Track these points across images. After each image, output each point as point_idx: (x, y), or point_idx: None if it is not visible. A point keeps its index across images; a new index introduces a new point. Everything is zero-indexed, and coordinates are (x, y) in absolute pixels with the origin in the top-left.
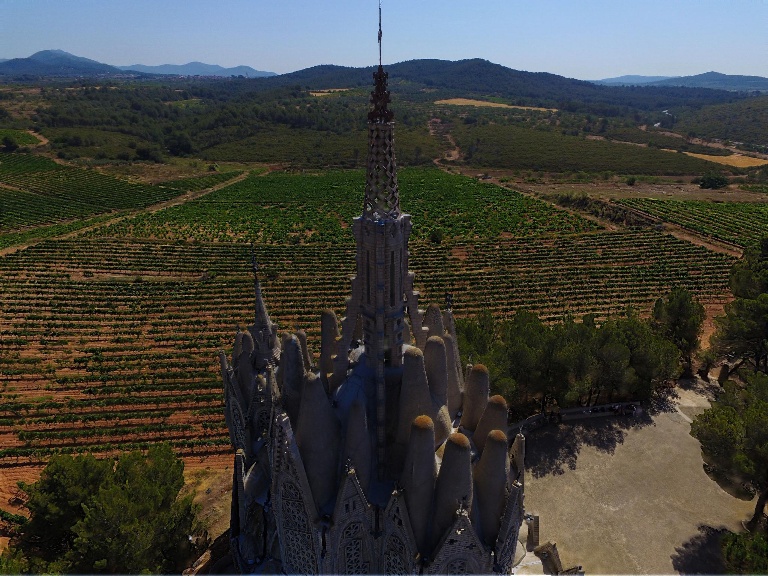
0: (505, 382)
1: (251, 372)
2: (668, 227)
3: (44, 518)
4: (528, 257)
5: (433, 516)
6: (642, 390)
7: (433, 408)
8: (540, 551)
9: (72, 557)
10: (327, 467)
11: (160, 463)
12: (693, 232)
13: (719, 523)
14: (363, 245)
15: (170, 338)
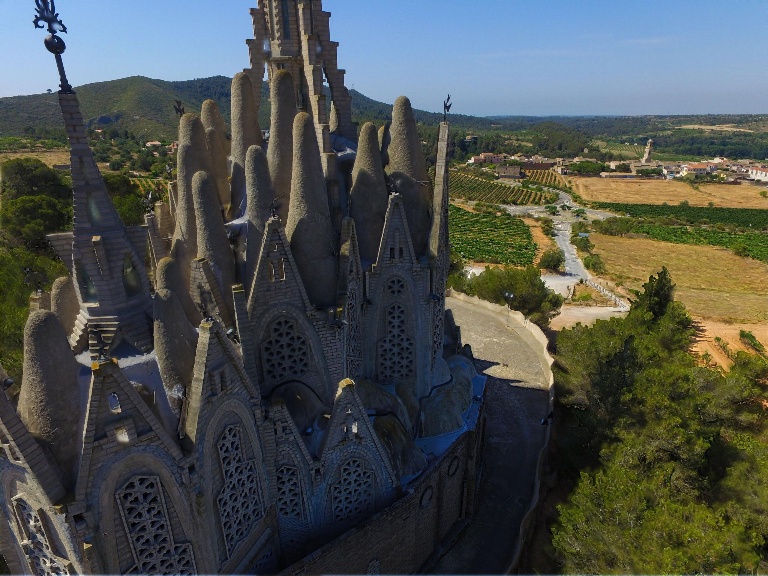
0: None
1: None
2: None
3: None
4: None
5: None
6: None
7: None
8: None
9: None
10: None
11: None
12: None
13: None
14: None
15: None
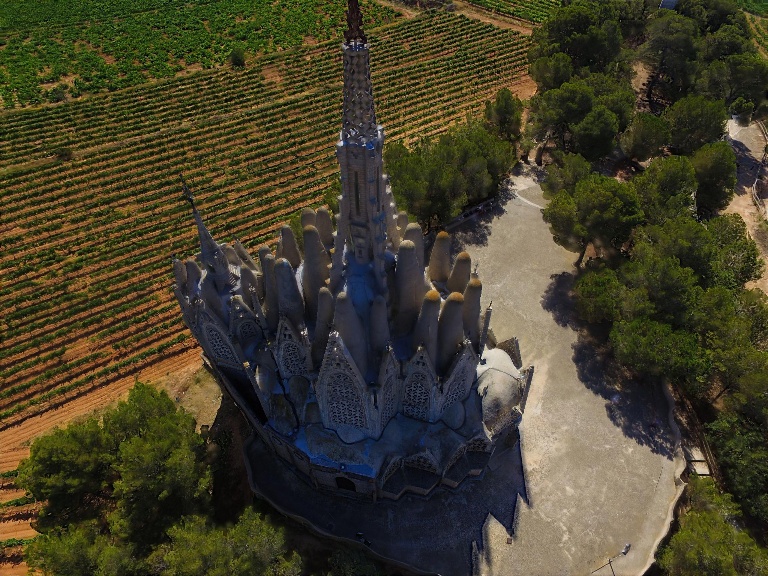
0: (410, 220)
1: (217, 295)
2: (458, 6)
3: (64, 493)
4: None
5: (439, 350)
6: (494, 188)
7: (422, 279)
8: None
9: (125, 504)
10: (363, 352)
11: None
12: (479, 8)
13: (560, 269)
14: (350, 167)
15: None
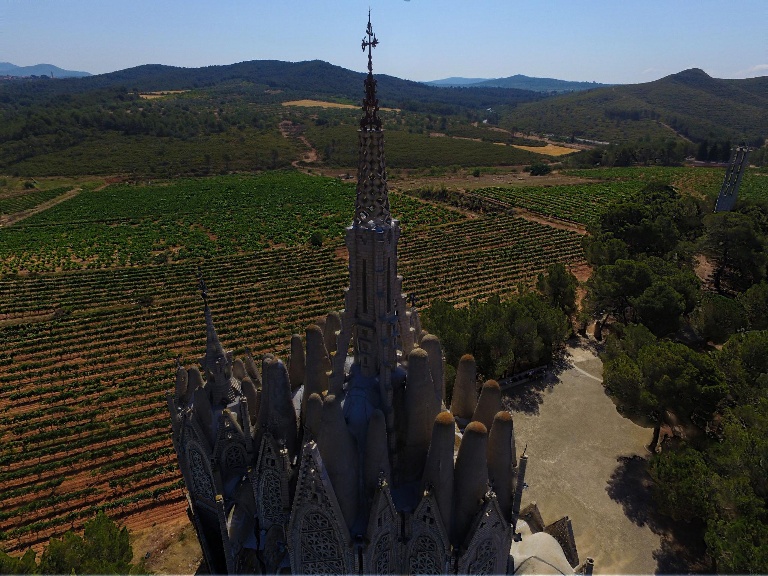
0: (447, 369)
1: (210, 408)
2: (517, 211)
3: None
4: (409, 250)
5: (456, 507)
6: (546, 355)
7: (437, 404)
8: (522, 514)
9: None
10: (352, 486)
11: (103, 538)
12: (537, 214)
13: (630, 452)
14: (358, 254)
15: (32, 393)
